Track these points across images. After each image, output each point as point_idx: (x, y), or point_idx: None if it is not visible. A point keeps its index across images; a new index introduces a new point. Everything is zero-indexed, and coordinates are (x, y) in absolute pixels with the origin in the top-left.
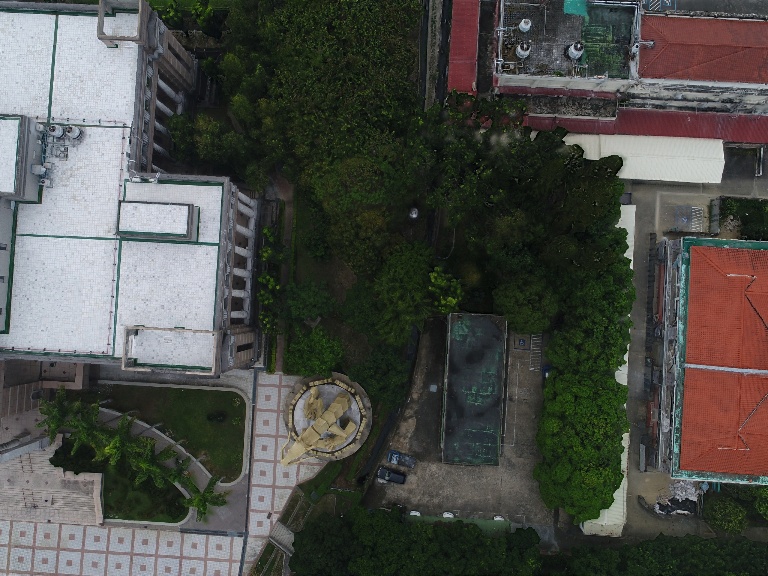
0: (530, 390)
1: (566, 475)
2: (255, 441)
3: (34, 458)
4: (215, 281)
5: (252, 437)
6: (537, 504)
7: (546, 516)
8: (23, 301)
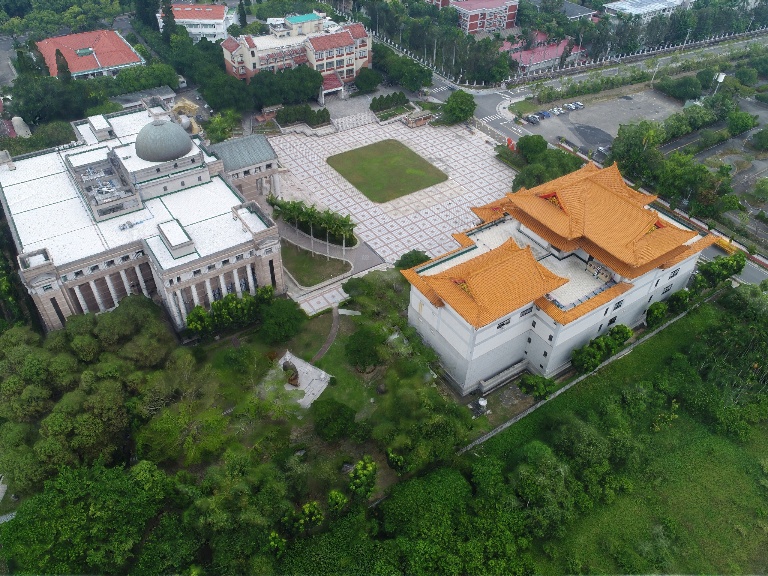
0: None
1: (158, 71)
2: None
3: None
4: None
5: None
6: (185, 95)
7: (188, 92)
8: None
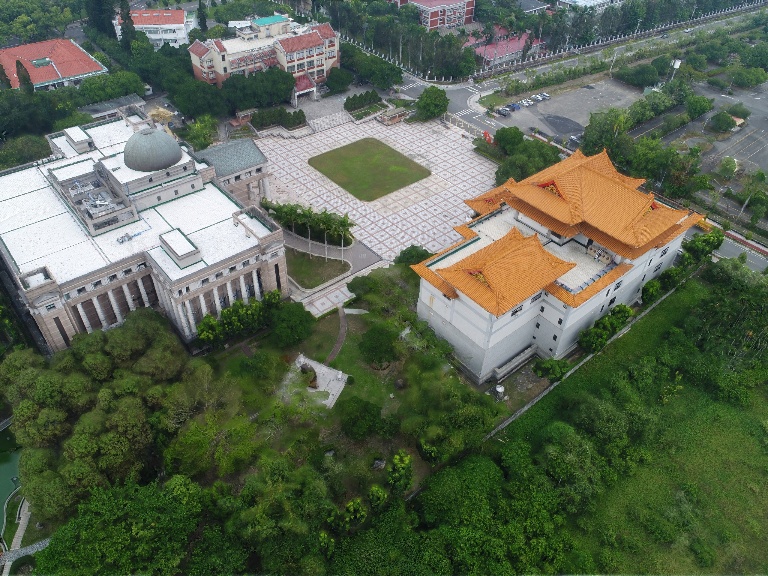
0: None
1: (124, 79)
2: None
3: None
4: None
5: None
6: None
7: None
8: None
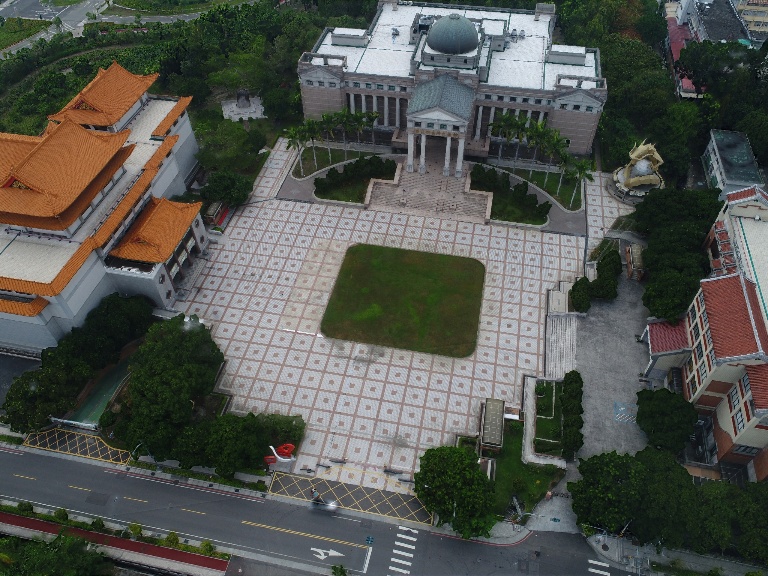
0: (764, 188)
1: None
2: (587, 197)
3: (450, 183)
4: (595, 76)
5: (585, 195)
6: None
7: None
8: (495, 75)
